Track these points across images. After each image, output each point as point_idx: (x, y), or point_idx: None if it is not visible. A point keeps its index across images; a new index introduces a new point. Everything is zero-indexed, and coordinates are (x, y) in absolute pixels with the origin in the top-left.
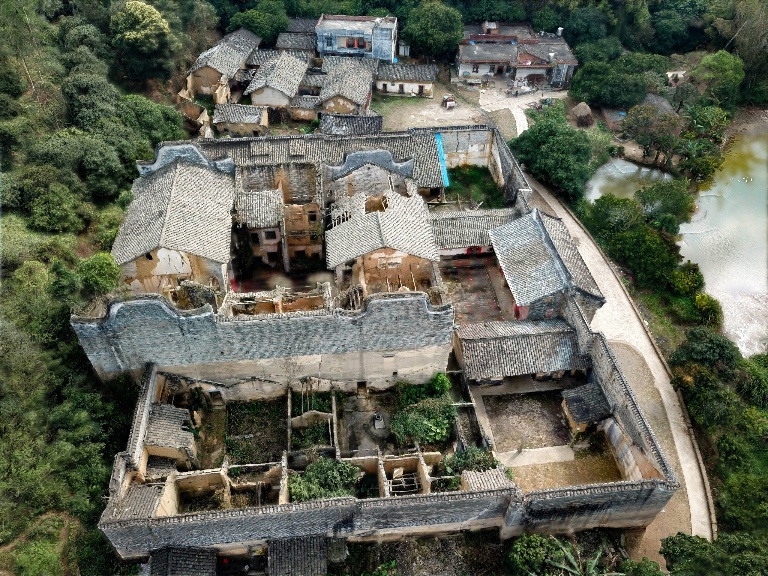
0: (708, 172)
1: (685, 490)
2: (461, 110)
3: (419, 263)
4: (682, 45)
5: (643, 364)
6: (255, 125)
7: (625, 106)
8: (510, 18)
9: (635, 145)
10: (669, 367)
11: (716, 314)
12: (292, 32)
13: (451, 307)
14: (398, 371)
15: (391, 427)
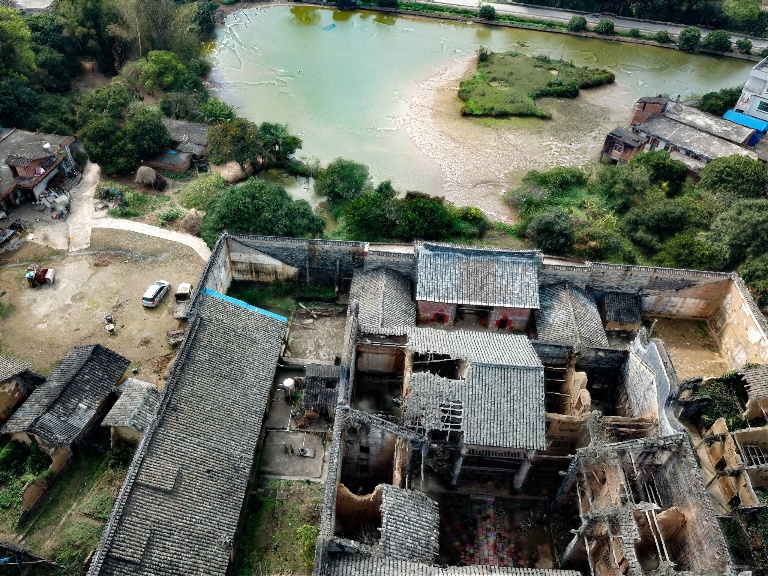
0: None
1: None
2: (64, 271)
3: None
4: None
5: None
6: None
7: None
8: None
9: (219, 168)
10: (551, 255)
11: None
12: None
13: None
14: None
15: None
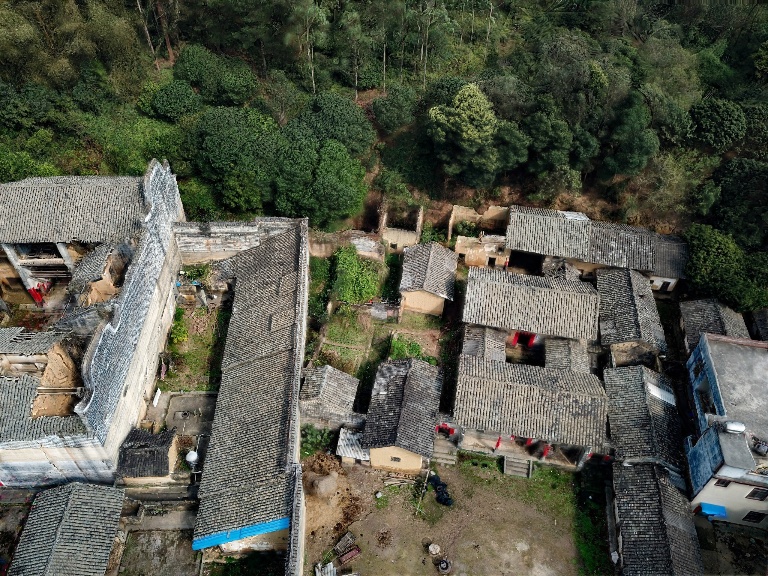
0: None
1: None
2: None
3: None
4: None
5: None
6: None
7: None
8: None
9: None
10: None
11: None
12: (757, 323)
13: None
14: None
15: None
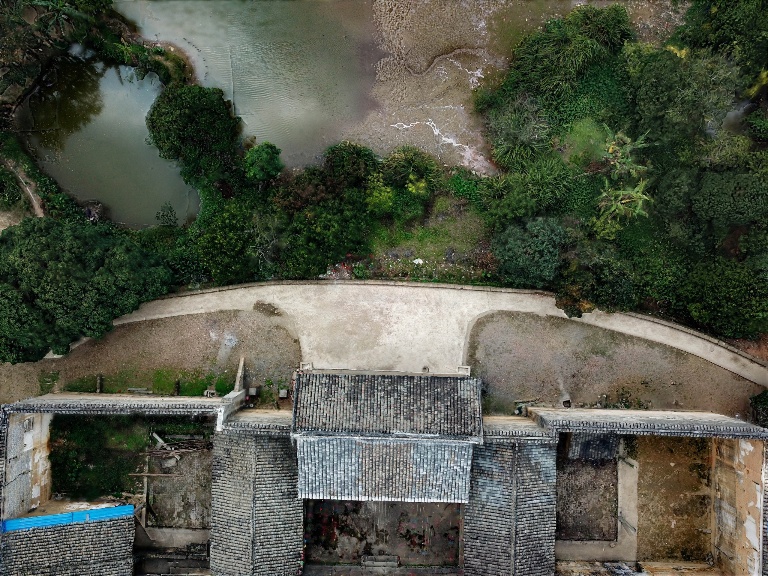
0: None
1: (675, 350)
2: None
3: None
4: None
5: (509, 316)
6: None
7: None
8: None
9: None
10: (522, 289)
11: (429, 169)
12: None
13: None
14: None
15: None
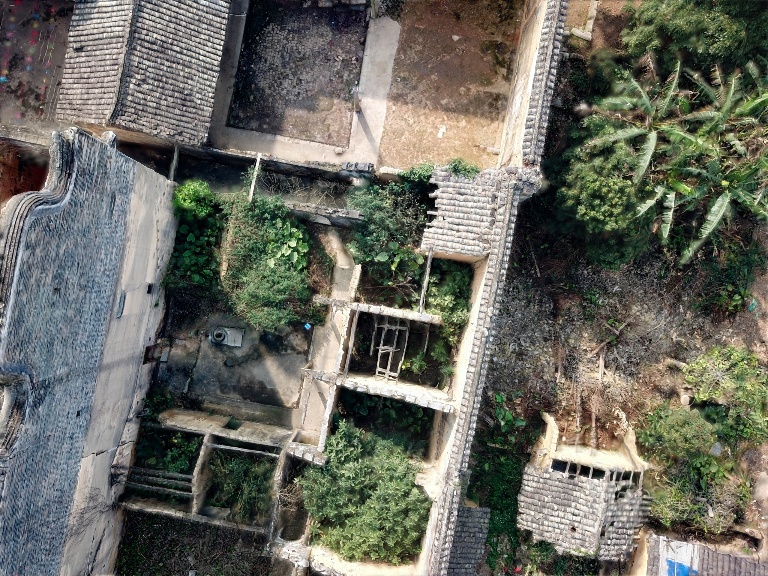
0: None
1: None
2: None
3: None
4: None
5: None
6: None
7: None
8: None
9: None
10: None
11: None
12: None
13: (69, 139)
14: (148, 282)
15: (262, 329)
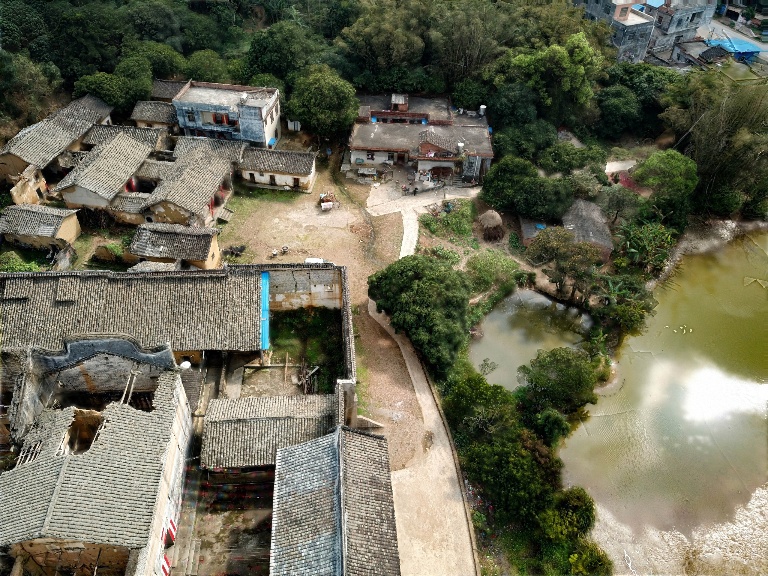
0: (631, 324)
1: None
2: (340, 213)
3: (115, 547)
4: (635, 128)
5: None
6: (50, 238)
7: (544, 217)
8: (425, 90)
9: None
10: None
11: None
12: (159, 98)
13: None
14: None
15: None
